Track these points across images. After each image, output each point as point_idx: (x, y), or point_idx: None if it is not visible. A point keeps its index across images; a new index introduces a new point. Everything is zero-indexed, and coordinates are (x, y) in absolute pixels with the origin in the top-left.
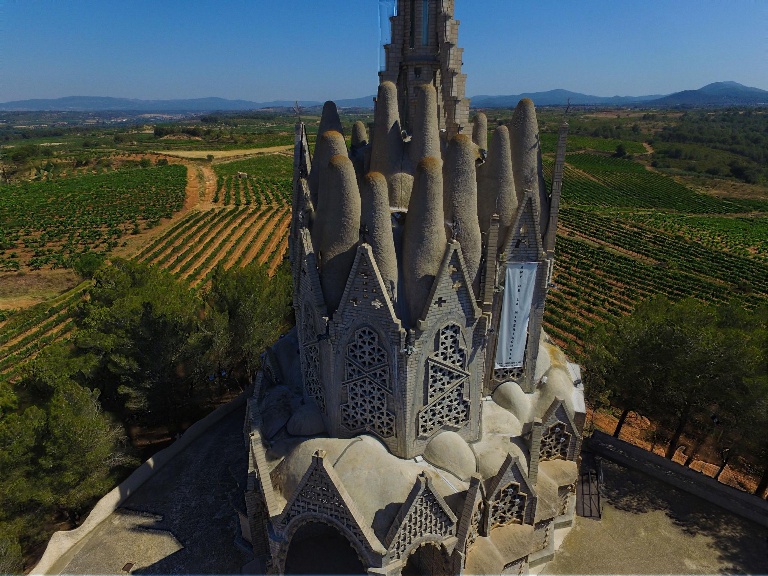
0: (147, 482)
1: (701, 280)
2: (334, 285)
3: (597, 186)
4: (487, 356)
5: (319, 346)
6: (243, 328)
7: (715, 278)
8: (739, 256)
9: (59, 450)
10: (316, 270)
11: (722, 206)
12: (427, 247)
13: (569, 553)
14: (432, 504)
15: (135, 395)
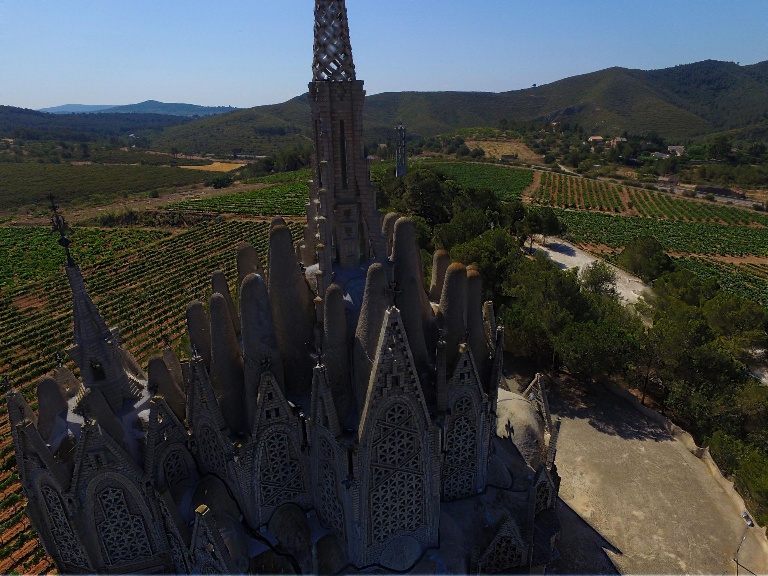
0: None
1: None
2: None
3: None
4: None
5: None
6: None
7: None
8: None
9: None
10: None
11: None
12: None
13: None
14: None
15: None
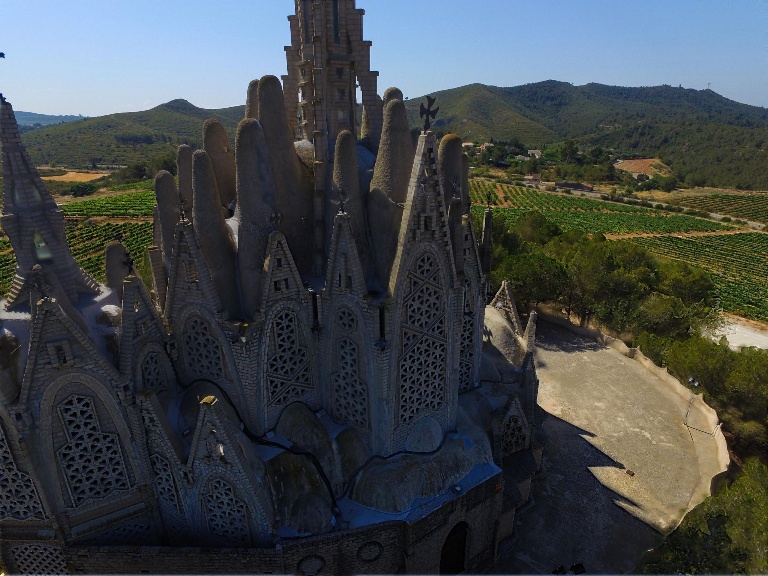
0: None
1: None
2: None
3: None
4: None
5: None
6: None
7: None
8: None
9: None
10: None
11: None
12: None
13: None
14: None
15: None
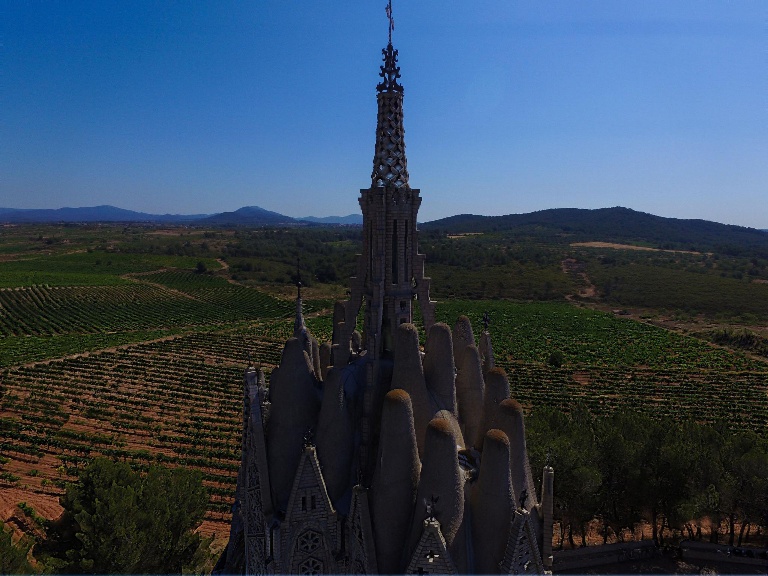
0: None
1: None
2: (463, 568)
3: (199, 304)
4: None
5: None
6: None
7: None
8: None
9: None
10: (453, 563)
11: None
12: (526, 482)
13: None
14: None
15: None
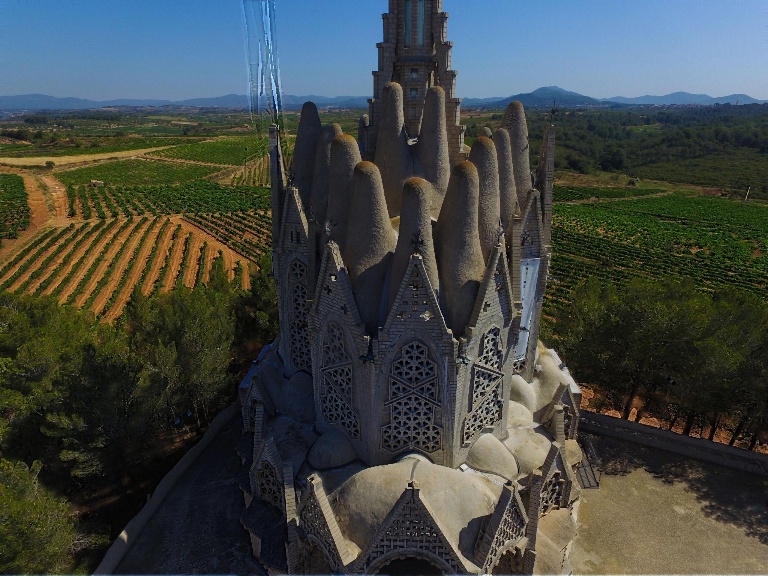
0: (123, 561)
1: (574, 260)
2: (368, 301)
3: None
4: None
5: (352, 368)
6: (188, 358)
7: (582, 257)
8: (594, 236)
9: (9, 550)
10: (349, 286)
11: (568, 194)
12: (468, 252)
13: (587, 525)
14: (512, 511)
15: (84, 459)
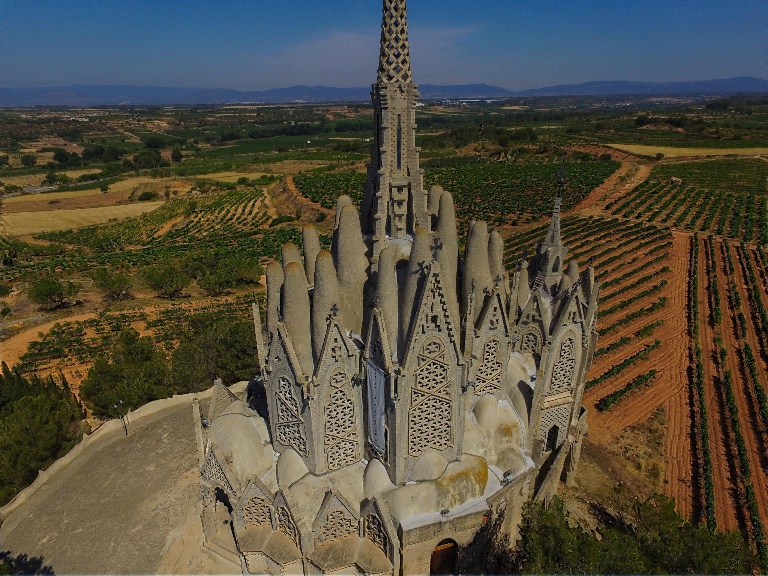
0: None
1: None
2: None
3: None
4: (365, 427)
5: None
6: None
7: None
8: None
9: None
10: None
11: None
12: (284, 320)
13: None
14: None
15: None
